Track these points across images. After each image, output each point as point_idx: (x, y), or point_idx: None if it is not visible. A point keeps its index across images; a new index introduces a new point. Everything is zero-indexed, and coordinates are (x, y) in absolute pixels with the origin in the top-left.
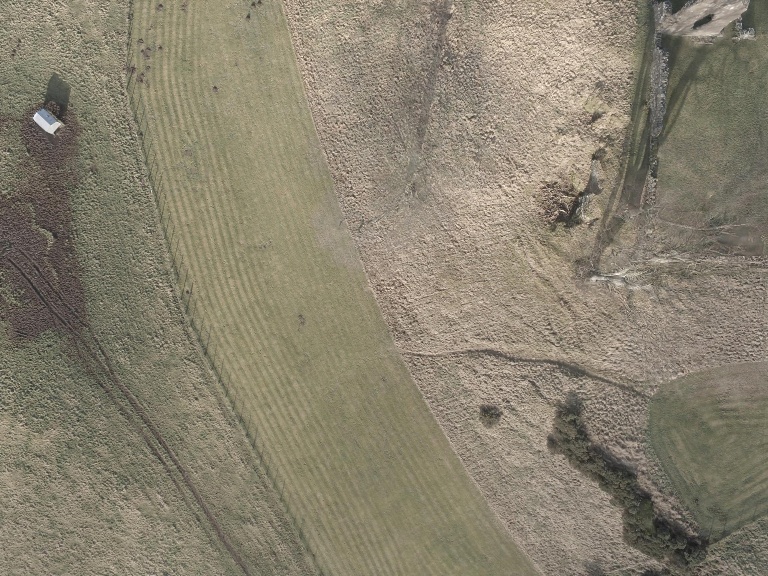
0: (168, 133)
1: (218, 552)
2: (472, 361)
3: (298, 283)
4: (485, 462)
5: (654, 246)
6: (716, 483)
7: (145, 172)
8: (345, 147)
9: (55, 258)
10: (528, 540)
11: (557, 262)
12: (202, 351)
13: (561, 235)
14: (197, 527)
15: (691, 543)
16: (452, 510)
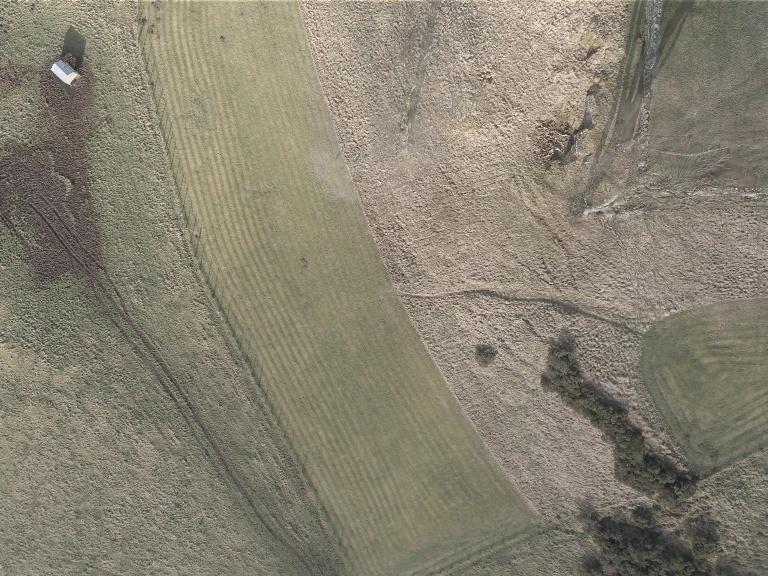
0: (177, 82)
1: (226, 485)
2: (468, 301)
3: (301, 227)
4: (481, 401)
5: (646, 179)
6: (707, 420)
7: (156, 121)
8: (346, 93)
9: (73, 204)
10: (522, 478)
11: (551, 200)
12: (210, 293)
13: (555, 173)
14: (206, 461)
15: (681, 478)
16: (448, 448)
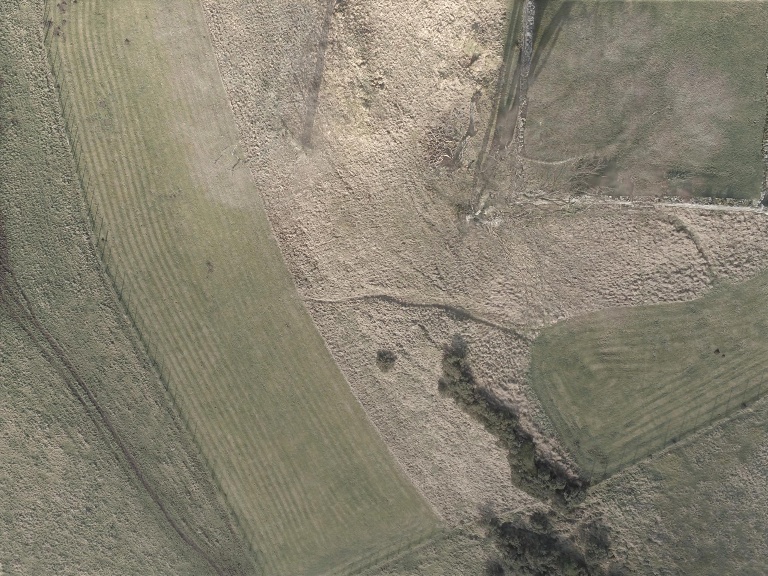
0: (83, 85)
1: (136, 490)
2: (368, 307)
3: (206, 231)
4: (384, 407)
5: (523, 186)
6: (597, 426)
7: (62, 123)
8: (249, 98)
9: None
10: (426, 483)
11: (441, 206)
12: (117, 296)
13: (444, 179)
14: (116, 465)
15: (572, 485)
16: (354, 453)
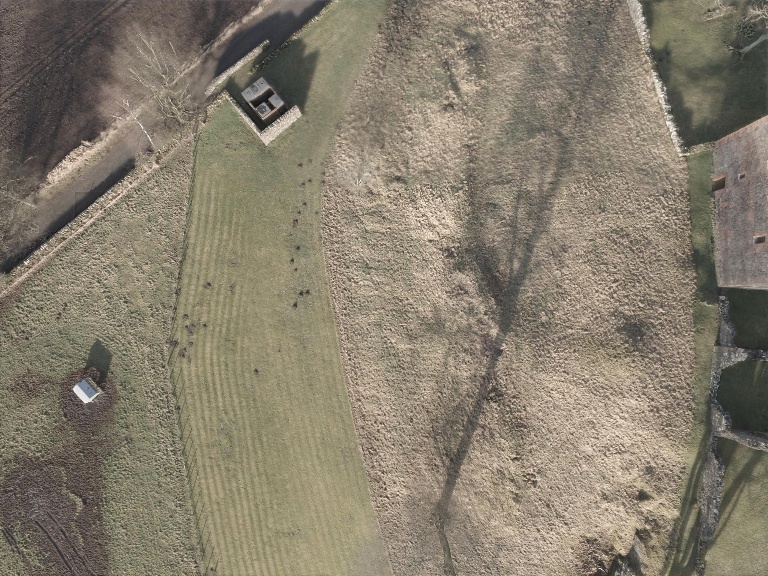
0: (205, 410)
1: None
2: None
3: (324, 574)
4: None
5: None
6: None
7: (179, 446)
8: (382, 447)
9: (82, 524)
10: None
11: None
12: None
13: None
14: None
15: None
16: None
